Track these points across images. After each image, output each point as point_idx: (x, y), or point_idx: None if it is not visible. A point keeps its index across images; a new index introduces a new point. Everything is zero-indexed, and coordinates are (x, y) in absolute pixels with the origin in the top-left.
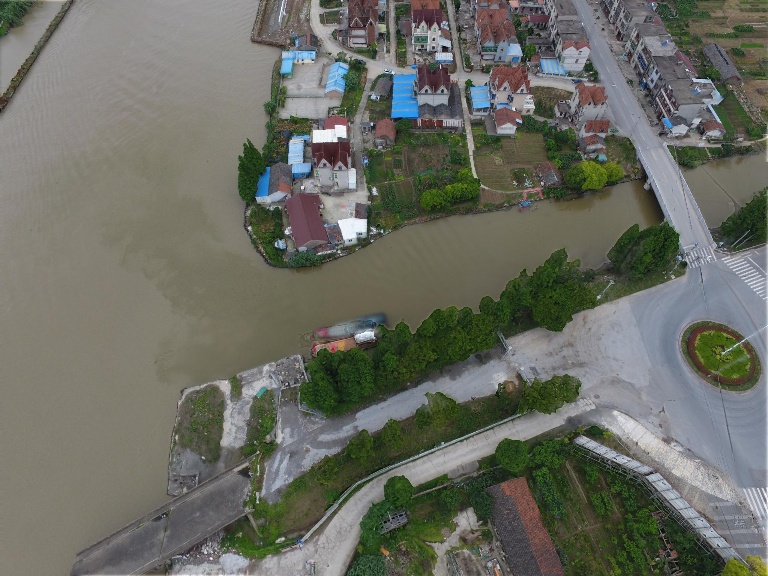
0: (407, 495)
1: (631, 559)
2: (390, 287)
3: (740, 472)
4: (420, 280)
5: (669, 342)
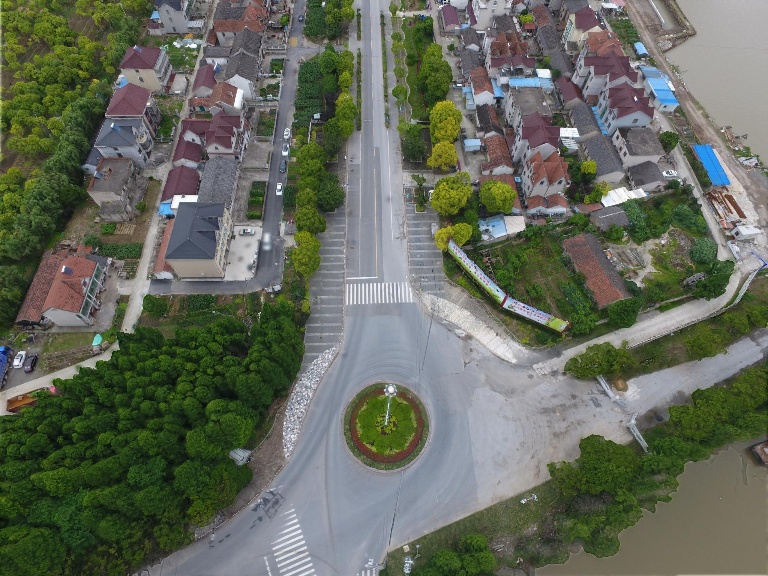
0: (707, 282)
1: (518, 257)
2: (767, 557)
3: (410, 314)
4: (730, 574)
5: (440, 441)
